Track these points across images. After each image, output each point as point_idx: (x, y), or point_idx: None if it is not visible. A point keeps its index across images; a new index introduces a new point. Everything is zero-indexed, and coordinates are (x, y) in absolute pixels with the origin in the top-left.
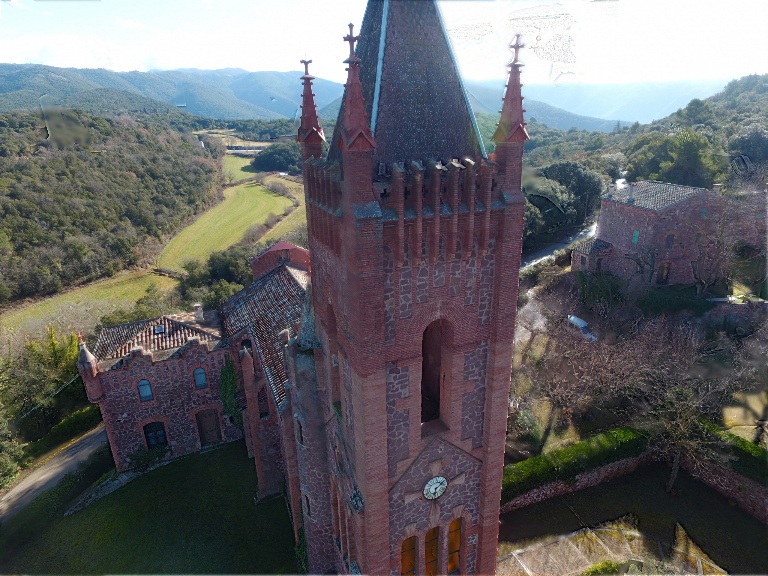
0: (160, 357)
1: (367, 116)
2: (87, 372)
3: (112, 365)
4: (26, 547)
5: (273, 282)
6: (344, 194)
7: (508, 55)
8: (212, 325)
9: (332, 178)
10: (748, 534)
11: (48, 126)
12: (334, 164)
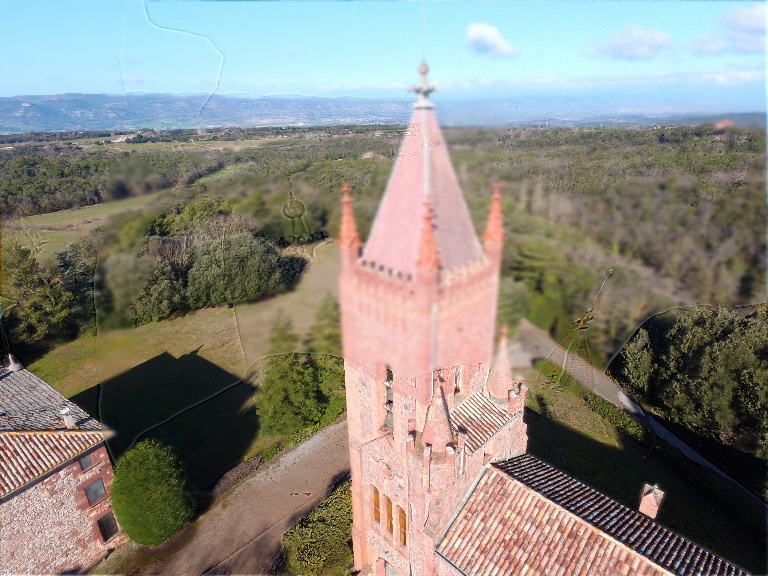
0: None
1: None
2: None
3: None
4: (749, 541)
5: None
6: None
7: (412, 254)
8: None
9: None
10: None
11: None
12: None
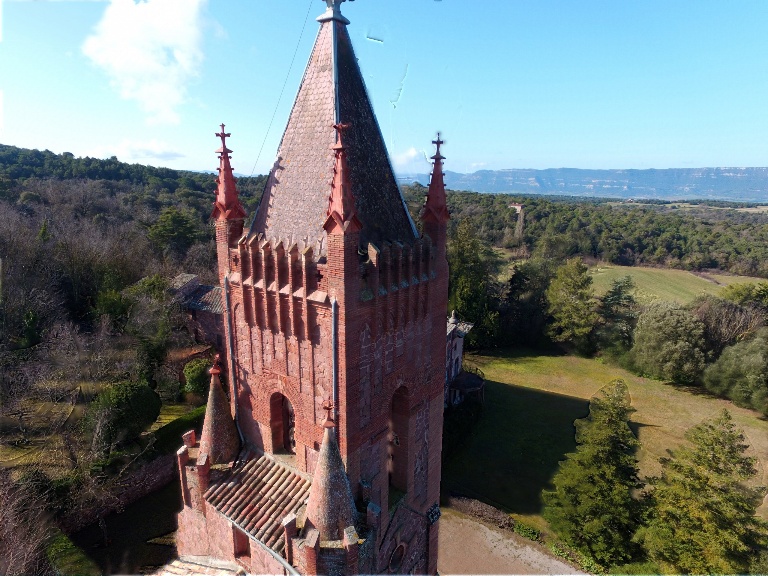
0: None
1: (394, 196)
2: None
3: None
4: None
5: None
6: (438, 256)
7: None
8: None
9: (431, 248)
10: (152, 507)
11: None
12: (428, 236)
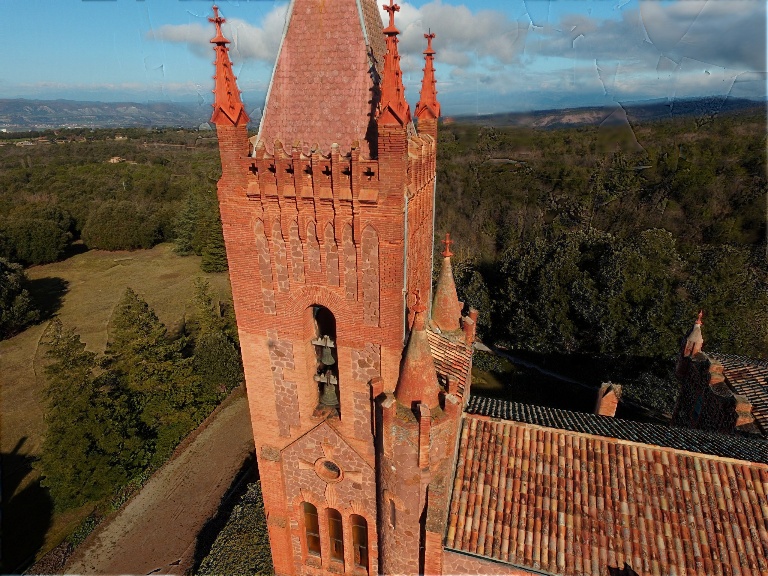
0: (717, 388)
1: None
2: (683, 347)
3: (700, 361)
4: None
5: None
6: None
7: None
8: None
9: None
10: None
11: None
12: None
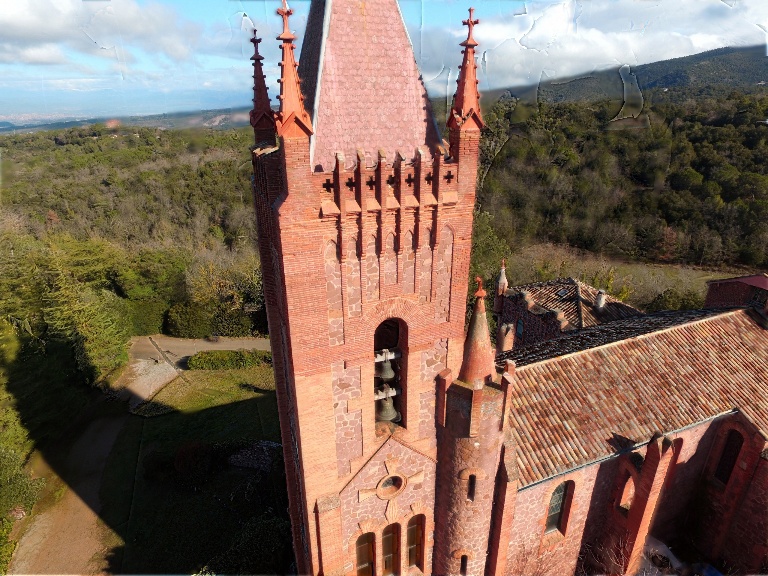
0: (534, 310)
1: None
2: (496, 289)
3: (511, 295)
4: None
5: (695, 315)
6: None
7: None
8: (604, 318)
9: None
10: None
11: (625, 94)
12: None
